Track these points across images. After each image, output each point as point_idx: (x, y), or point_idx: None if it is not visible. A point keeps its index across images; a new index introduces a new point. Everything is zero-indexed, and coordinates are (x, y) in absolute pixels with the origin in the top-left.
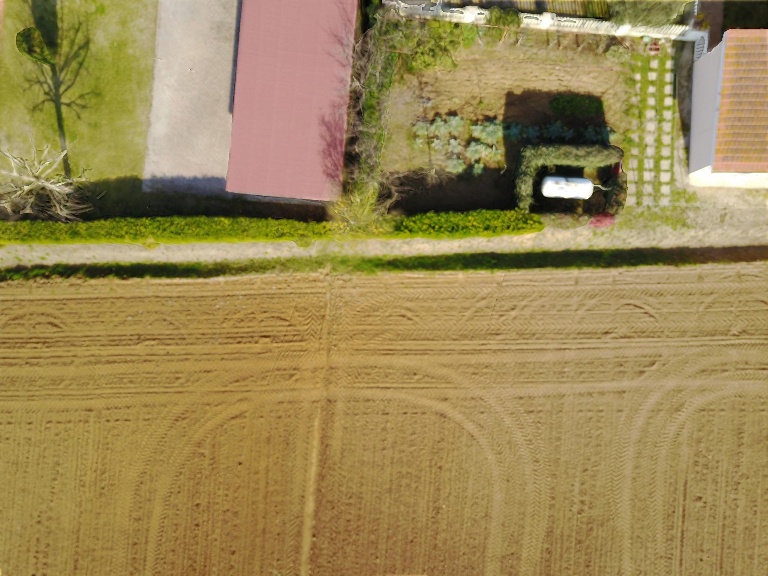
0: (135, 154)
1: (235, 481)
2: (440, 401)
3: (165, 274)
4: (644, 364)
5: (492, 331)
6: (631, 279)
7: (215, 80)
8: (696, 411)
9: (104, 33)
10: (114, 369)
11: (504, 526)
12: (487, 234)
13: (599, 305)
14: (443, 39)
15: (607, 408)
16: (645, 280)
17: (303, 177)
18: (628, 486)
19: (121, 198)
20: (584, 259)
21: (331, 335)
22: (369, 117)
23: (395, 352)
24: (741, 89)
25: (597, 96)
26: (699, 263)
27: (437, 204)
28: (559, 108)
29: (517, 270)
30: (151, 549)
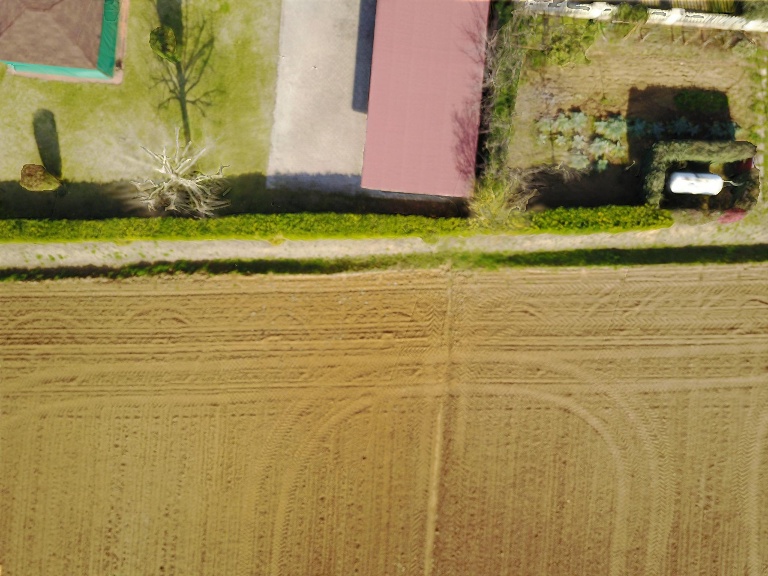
0: (259, 151)
1: (359, 475)
2: (564, 396)
3: (288, 270)
4: None
5: (616, 327)
6: (756, 275)
7: (338, 77)
8: None
9: (228, 31)
10: (239, 364)
11: (629, 521)
12: (616, 230)
13: (724, 301)
14: (579, 35)
15: (733, 404)
16: None
17: (436, 173)
18: (755, 482)
19: (246, 195)
20: (708, 255)
21: (453, 331)
22: (498, 113)
23: (517, 348)
24: None
25: (722, 92)
26: None
27: (560, 200)
28: (684, 104)
29: (641, 266)
30: (277, 542)
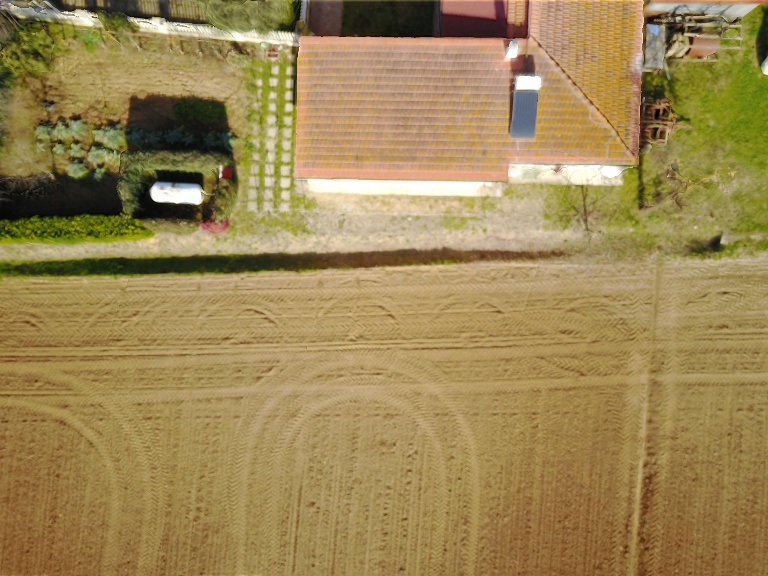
0: None
1: None
2: (59, 408)
3: None
4: (262, 370)
5: (114, 337)
6: (253, 284)
7: None
8: (312, 416)
9: None
10: None
11: (121, 534)
12: (92, 239)
13: (220, 311)
14: (26, 42)
15: (224, 414)
16: (266, 285)
17: None
18: (244, 492)
19: None
20: (210, 264)
21: None
22: None
23: (18, 359)
24: (316, 96)
25: (221, 101)
26: (319, 268)
27: (60, 209)
28: (182, 113)
29: (140, 275)
30: None
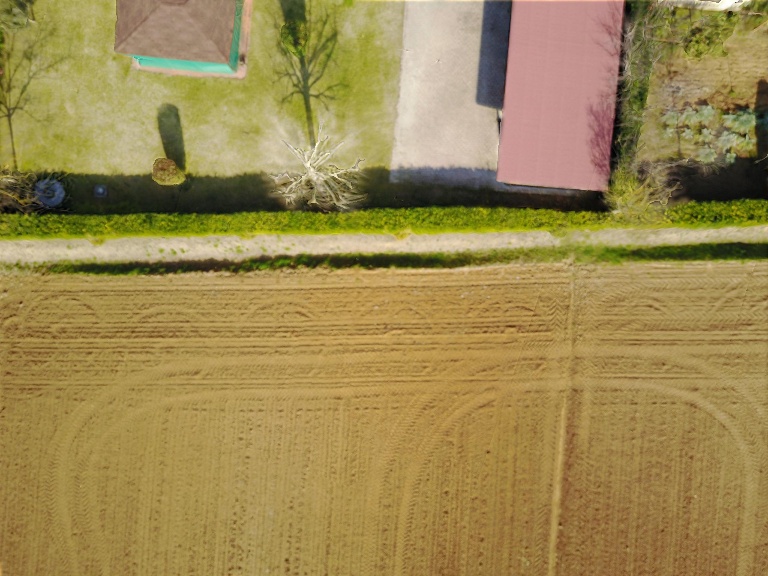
0: (382, 145)
1: (483, 469)
2: (690, 391)
3: (410, 264)
4: None
5: (743, 321)
6: None
7: (462, 71)
8: None
9: (352, 25)
10: (362, 358)
11: (757, 517)
12: (749, 224)
13: None
14: (720, 27)
15: None
16: None
17: (571, 167)
18: None
19: (369, 189)
20: None
21: (576, 325)
22: None
23: (642, 342)
24: None
25: None
26: None
27: (686, 194)
28: None
29: None
30: (401, 535)
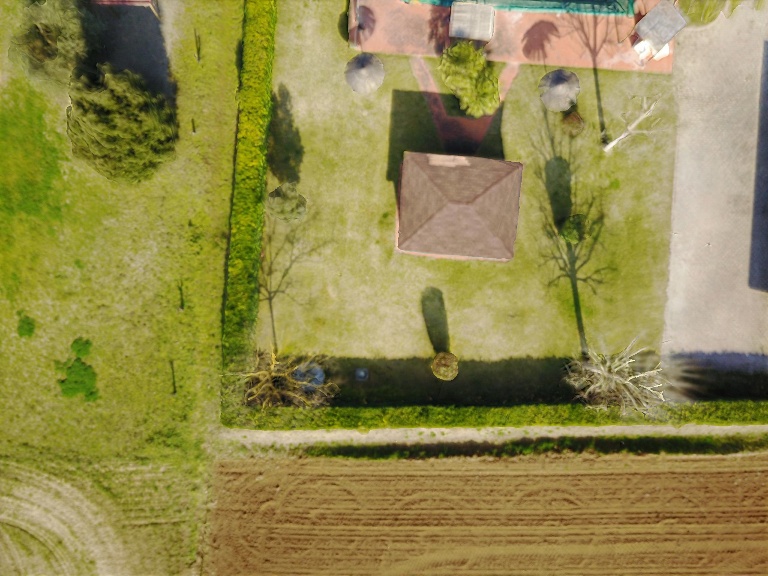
0: (652, 329)
1: None
2: None
3: (681, 450)
4: None
5: None
6: None
7: (733, 254)
8: None
9: (619, 208)
10: (634, 548)
11: None
12: None
13: None
14: None
15: None
16: None
17: None
18: None
19: None
20: None
21: None
22: None
23: None
24: None
25: None
26: None
27: None
28: None
29: None
30: None
